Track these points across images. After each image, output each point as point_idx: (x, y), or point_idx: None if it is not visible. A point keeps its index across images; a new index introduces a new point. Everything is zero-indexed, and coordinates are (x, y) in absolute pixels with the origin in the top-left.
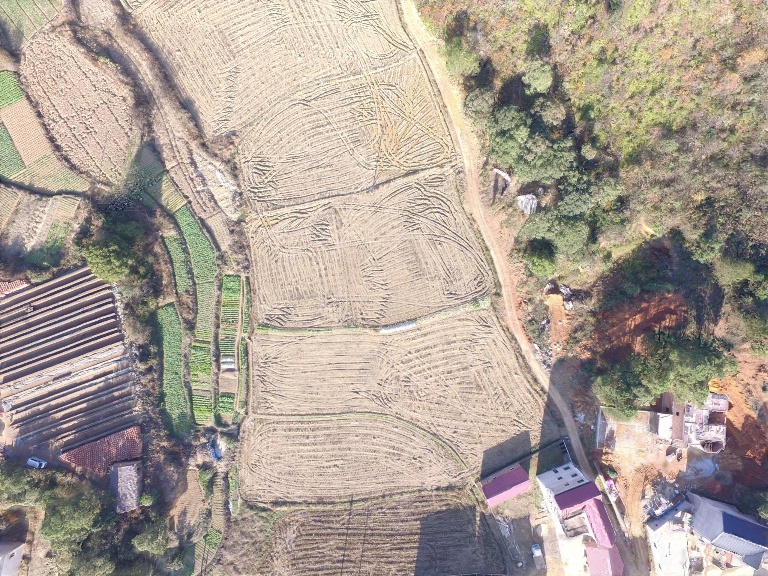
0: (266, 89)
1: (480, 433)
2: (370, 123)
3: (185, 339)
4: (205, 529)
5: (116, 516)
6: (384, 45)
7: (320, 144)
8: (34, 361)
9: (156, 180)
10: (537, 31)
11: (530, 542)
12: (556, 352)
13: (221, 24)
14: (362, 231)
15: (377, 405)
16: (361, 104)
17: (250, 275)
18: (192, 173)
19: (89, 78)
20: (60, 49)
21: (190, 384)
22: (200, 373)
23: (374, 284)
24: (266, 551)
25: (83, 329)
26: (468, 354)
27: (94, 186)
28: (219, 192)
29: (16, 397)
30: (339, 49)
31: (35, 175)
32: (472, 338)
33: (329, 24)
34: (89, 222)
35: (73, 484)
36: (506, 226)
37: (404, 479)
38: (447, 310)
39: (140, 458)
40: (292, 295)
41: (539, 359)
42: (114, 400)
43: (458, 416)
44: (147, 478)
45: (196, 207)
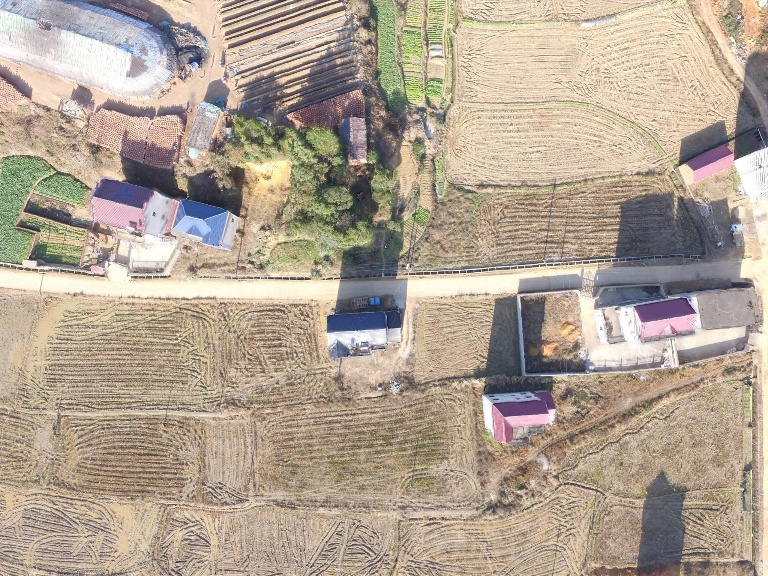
0: None
1: (678, 122)
2: None
3: (399, 21)
4: (415, 206)
5: None
6: None
7: None
8: (260, 28)
9: None
10: None
11: (728, 223)
12: (750, 46)
13: None
14: None
15: (578, 95)
16: None
17: None
18: None
19: None
20: None
21: (402, 66)
22: (411, 55)
23: None
24: (472, 231)
25: None
26: (665, 48)
27: None
28: None
29: (241, 63)
30: None
31: None
32: (669, 34)
33: None
34: None
35: None
36: None
37: (605, 165)
38: (645, 6)
39: None
40: None
41: (735, 52)
42: (337, 66)
43: (656, 106)
44: (371, 138)
45: None
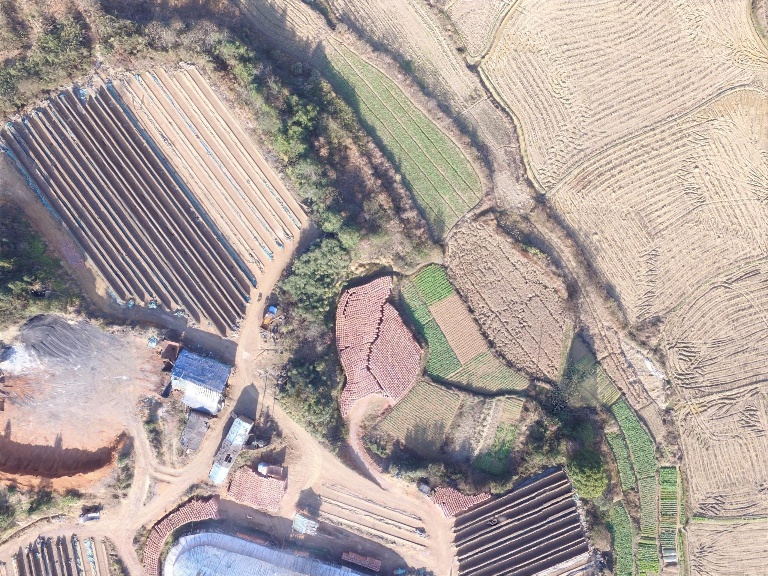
0: (687, 272)
1: None
2: None
3: (636, 538)
4: None
5: None
6: None
7: (744, 328)
8: (501, 575)
9: (590, 373)
10: None
11: None
12: None
13: (637, 205)
14: None
15: None
16: None
17: (682, 464)
18: (624, 364)
19: (519, 270)
20: (485, 239)
21: None
22: (648, 571)
23: None
24: None
25: (550, 540)
26: None
27: (533, 383)
28: (649, 381)
29: None
30: (757, 229)
31: (472, 374)
32: None
33: (746, 203)
34: (542, 426)
35: None
36: None
37: None
38: None
39: None
40: (725, 483)
41: None
42: None
43: None
44: None
45: (631, 399)
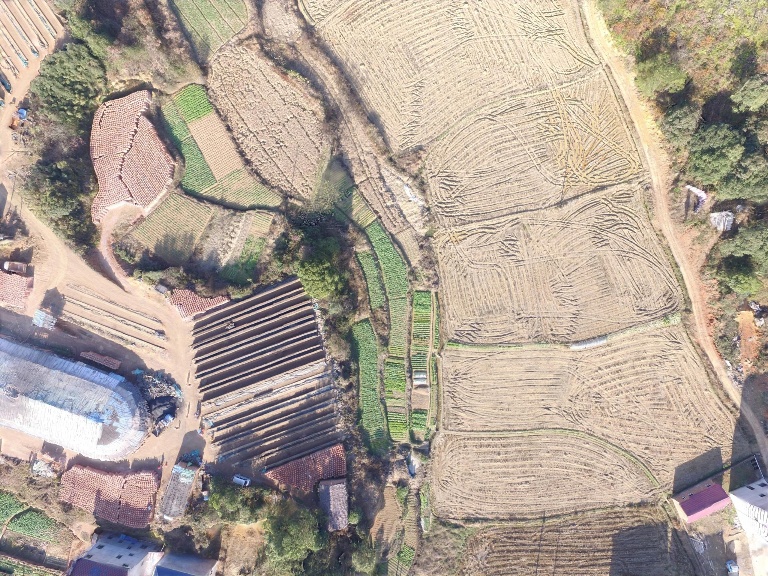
0: (452, 104)
1: (671, 449)
2: (557, 138)
3: (381, 355)
4: (400, 546)
5: (327, 535)
6: (569, 60)
7: (507, 159)
8: (236, 378)
9: (346, 195)
10: (745, 49)
11: (724, 558)
12: (747, 368)
13: (405, 38)
14: (551, 247)
15: (568, 421)
16: (547, 119)
17: (439, 291)
18: (381, 188)
19: (278, 92)
20: (248, 62)
21: (385, 400)
22: (395, 389)
23: (564, 300)
24: (458, 568)
25: (286, 346)
26: (658, 370)
27: (286, 201)
28: (408, 207)
29: (217, 414)
30: (524, 64)
31: (226, 190)
32: (662, 354)
33: (514, 39)
34: (287, 238)
35: (280, 502)
36: (698, 243)
37: (596, 495)
38: (637, 326)
39: (345, 476)
40: (482, 311)
41: (730, 375)
42: (317, 417)
43: (649, 432)
44: (352, 496)
45: (386, 222)
